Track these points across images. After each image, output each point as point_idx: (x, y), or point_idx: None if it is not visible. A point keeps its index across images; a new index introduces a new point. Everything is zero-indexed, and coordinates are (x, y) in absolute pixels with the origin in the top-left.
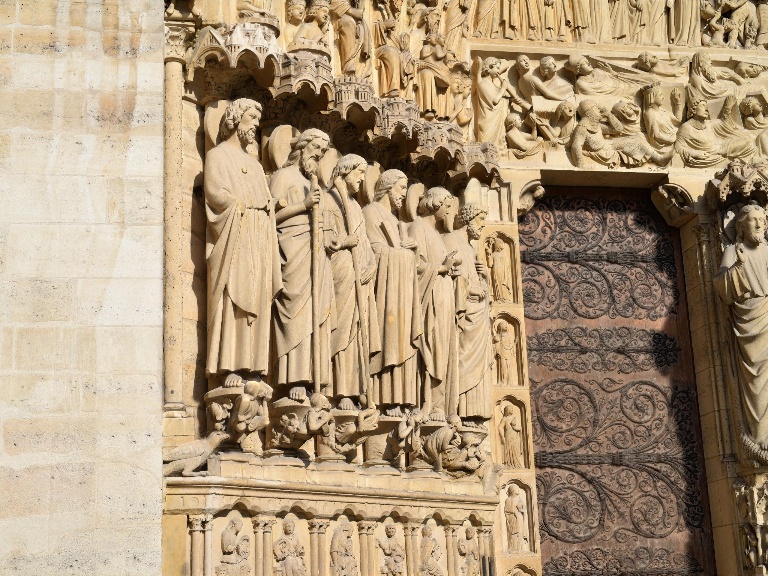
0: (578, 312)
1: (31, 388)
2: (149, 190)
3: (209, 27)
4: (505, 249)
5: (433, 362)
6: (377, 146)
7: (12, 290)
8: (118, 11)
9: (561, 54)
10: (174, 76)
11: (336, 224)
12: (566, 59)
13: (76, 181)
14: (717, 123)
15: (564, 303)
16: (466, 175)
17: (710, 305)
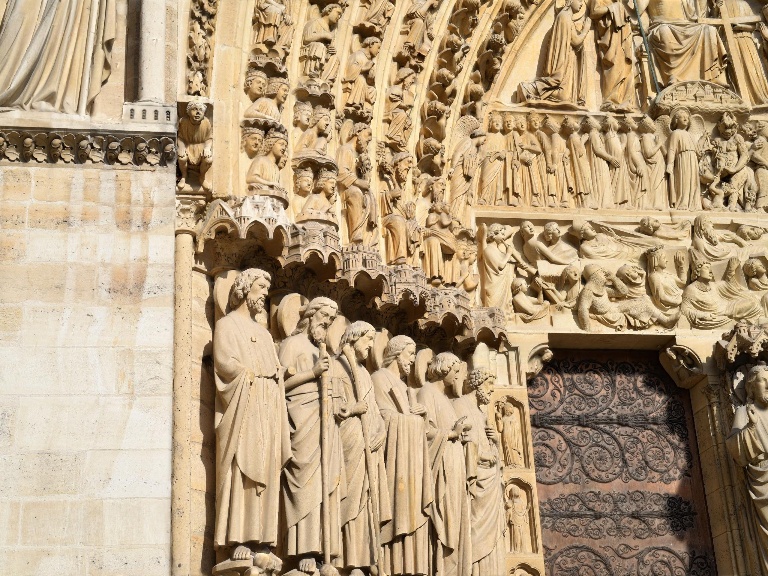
0: (590, 476)
1: (36, 564)
2: (159, 361)
3: (219, 200)
4: (515, 413)
5: (445, 530)
6: (385, 313)
7: (20, 463)
8: (131, 186)
9: (564, 220)
10: (184, 248)
11: (345, 391)
12: (570, 224)
13: (86, 353)
14: (722, 285)
15: (576, 467)
16: (474, 340)
17: (724, 467)
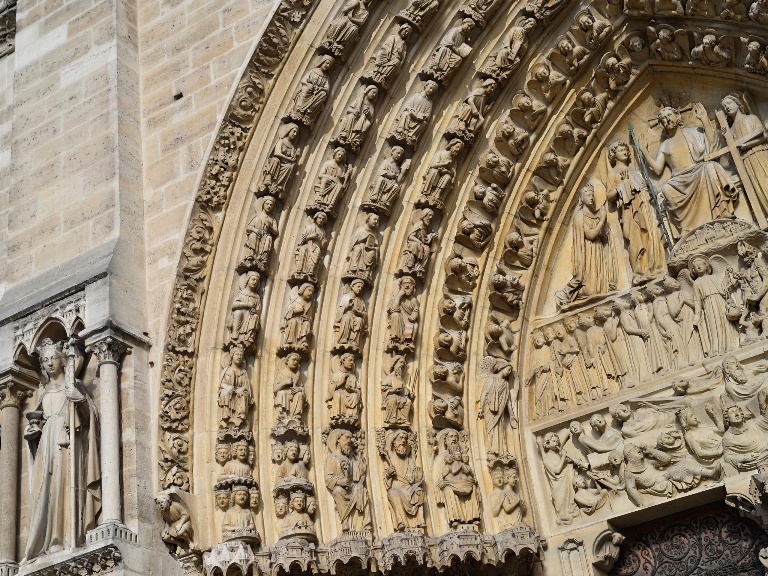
0: None
1: None
2: None
3: (205, 553)
4: None
5: None
6: (403, 571)
7: None
8: None
9: (608, 407)
10: None
11: None
12: None
13: None
14: (760, 420)
15: None
16: (502, 562)
17: None
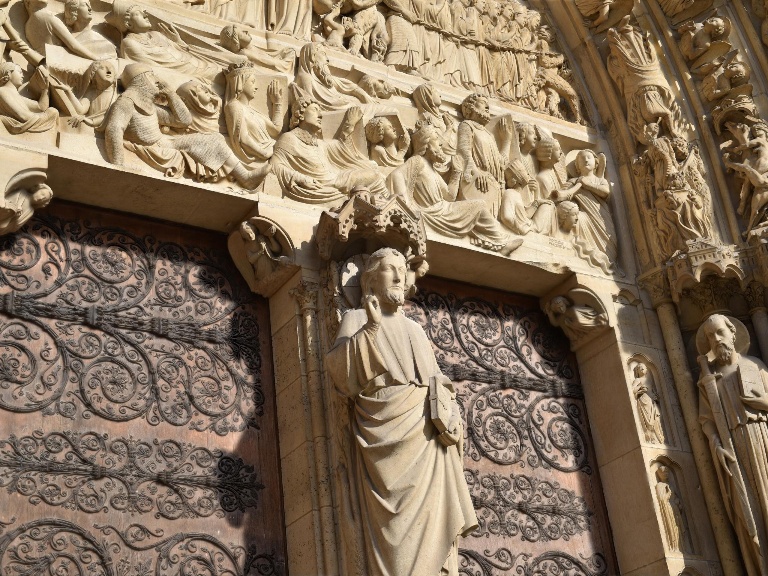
0: (93, 407)
1: None
2: None
3: None
4: None
5: None
6: None
7: None
8: None
9: (101, 0)
10: None
11: None
12: (109, 11)
13: None
14: (333, 144)
15: (69, 390)
16: None
17: (316, 407)
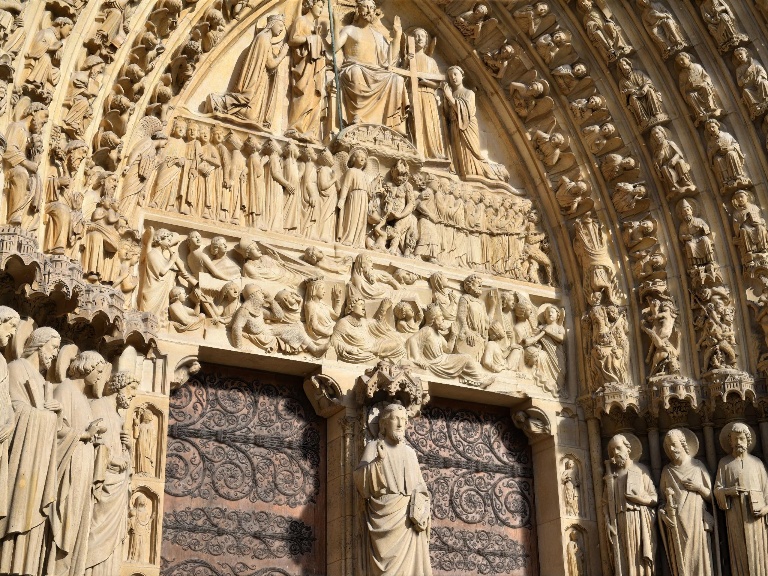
0: (219, 492)
1: None
2: None
3: None
4: (153, 421)
5: (62, 532)
6: (34, 301)
7: None
8: None
9: (233, 236)
10: None
11: None
12: (237, 242)
13: None
14: (372, 322)
15: (206, 482)
16: (123, 342)
17: (348, 497)
